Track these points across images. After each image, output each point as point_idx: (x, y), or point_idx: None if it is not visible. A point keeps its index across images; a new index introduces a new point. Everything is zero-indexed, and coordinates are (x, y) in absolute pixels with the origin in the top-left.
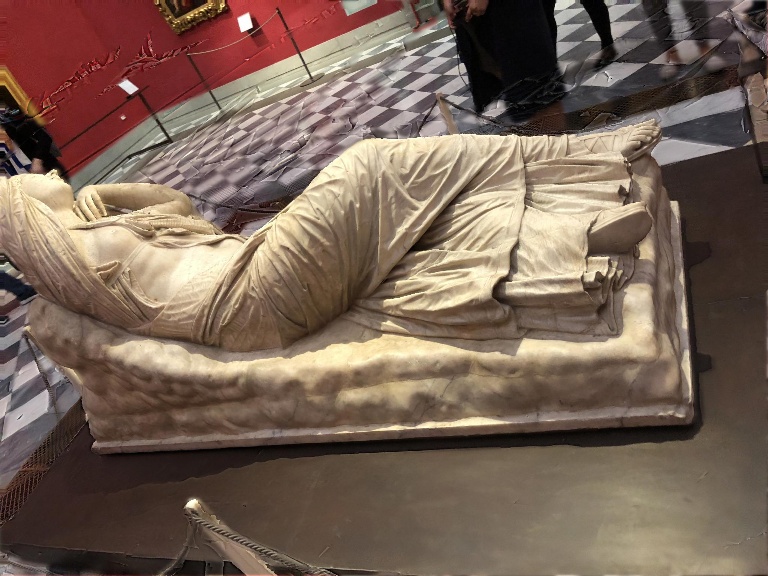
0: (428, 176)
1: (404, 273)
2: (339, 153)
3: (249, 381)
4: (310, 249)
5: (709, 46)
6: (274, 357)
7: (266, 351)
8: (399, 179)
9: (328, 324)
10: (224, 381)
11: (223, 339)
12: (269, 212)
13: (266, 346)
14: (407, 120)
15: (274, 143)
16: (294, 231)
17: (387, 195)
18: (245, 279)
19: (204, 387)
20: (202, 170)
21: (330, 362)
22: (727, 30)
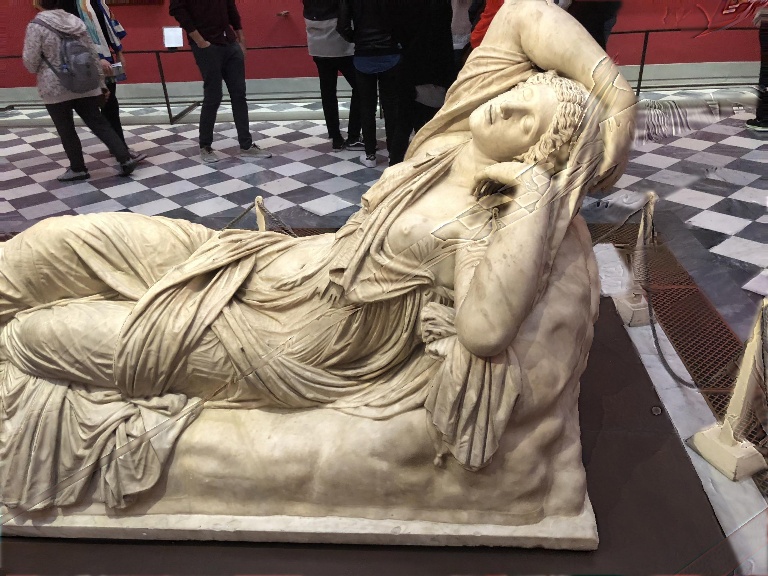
0: None
1: None
2: None
3: None
4: None
5: None
6: None
7: None
8: None
9: None
10: None
11: None
12: None
13: None
14: None
15: None
16: None
17: None
18: None
19: None
20: None
21: None
22: None
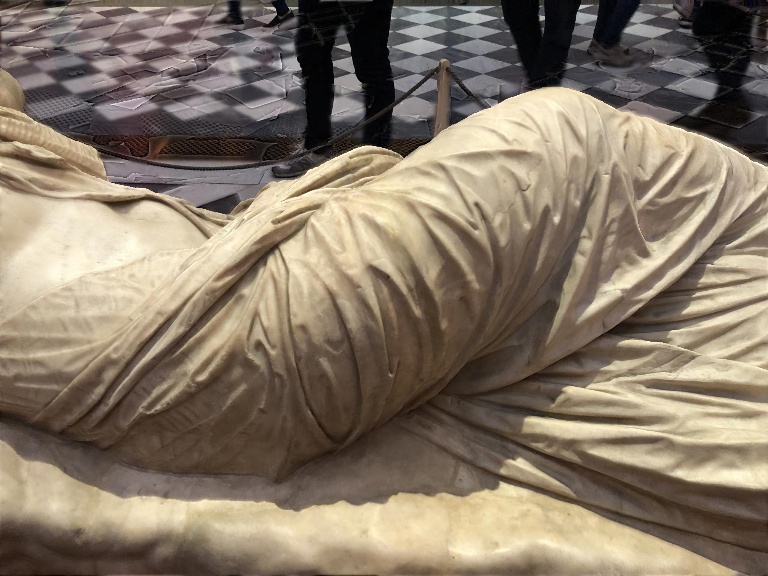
0: (677, 197)
1: (579, 372)
2: (243, 99)
3: (185, 554)
4: (437, 289)
5: (671, 116)
6: (253, 500)
7: (229, 479)
8: (632, 188)
9: (370, 434)
10: (115, 546)
11: (129, 440)
12: (113, 154)
13: (232, 468)
14: (364, 84)
15: (150, 50)
16: (411, 240)
17: (606, 213)
18: (233, 316)
19: (50, 552)
20: (6, 52)
21: (408, 542)
22: (684, 105)
